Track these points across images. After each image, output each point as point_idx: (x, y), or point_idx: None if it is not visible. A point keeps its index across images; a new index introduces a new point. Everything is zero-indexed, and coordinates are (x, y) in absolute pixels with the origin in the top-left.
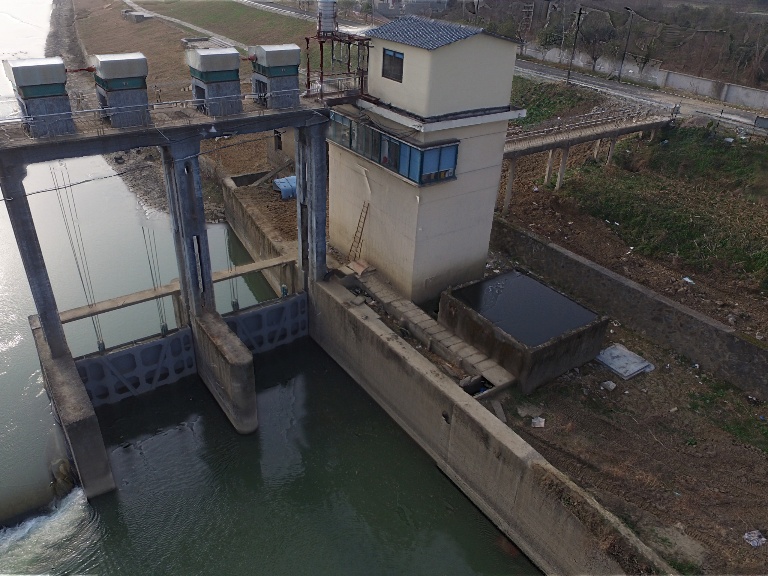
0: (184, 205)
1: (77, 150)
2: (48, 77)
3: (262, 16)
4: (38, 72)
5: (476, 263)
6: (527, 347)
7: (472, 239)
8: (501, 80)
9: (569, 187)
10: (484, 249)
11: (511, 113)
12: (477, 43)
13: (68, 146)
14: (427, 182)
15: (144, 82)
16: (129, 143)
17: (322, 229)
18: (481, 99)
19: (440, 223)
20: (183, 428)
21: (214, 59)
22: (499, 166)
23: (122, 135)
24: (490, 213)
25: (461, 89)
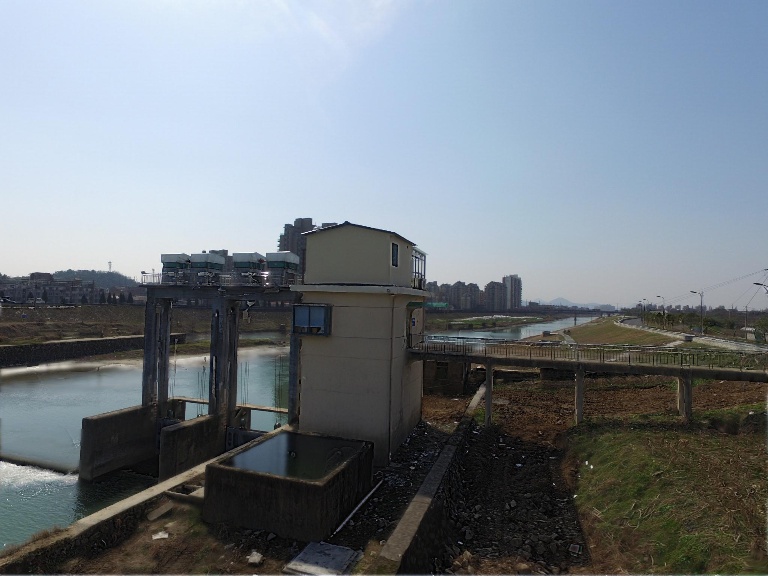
0: (212, 335)
1: (173, 294)
2: (171, 259)
3: (615, 330)
4: (168, 257)
5: (371, 439)
6: (215, 462)
7: (363, 409)
8: (379, 263)
9: (585, 422)
10: (380, 427)
11: (378, 288)
12: (347, 233)
13: (170, 291)
14: (299, 333)
15: (206, 265)
16: (194, 294)
17: (294, 380)
18: (358, 276)
19: (324, 379)
20: (156, 479)
21: (238, 255)
22: (385, 340)
23: (182, 286)
24: (382, 387)
25: (336, 266)
